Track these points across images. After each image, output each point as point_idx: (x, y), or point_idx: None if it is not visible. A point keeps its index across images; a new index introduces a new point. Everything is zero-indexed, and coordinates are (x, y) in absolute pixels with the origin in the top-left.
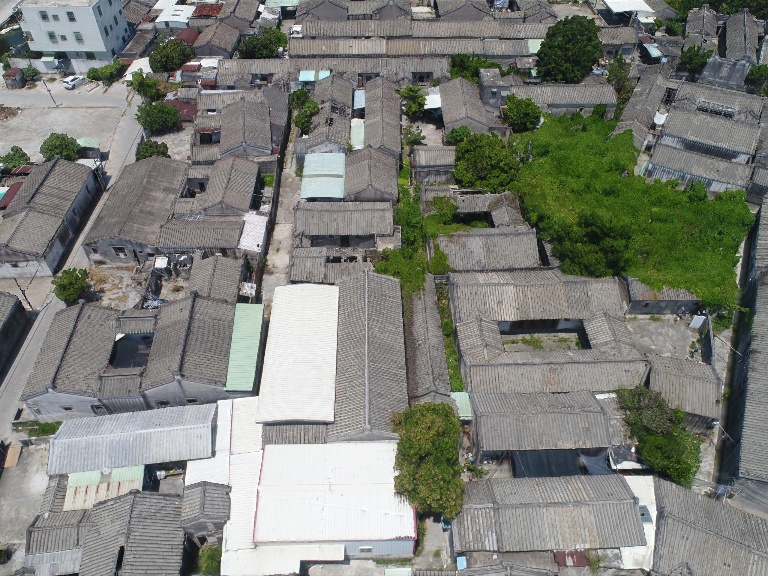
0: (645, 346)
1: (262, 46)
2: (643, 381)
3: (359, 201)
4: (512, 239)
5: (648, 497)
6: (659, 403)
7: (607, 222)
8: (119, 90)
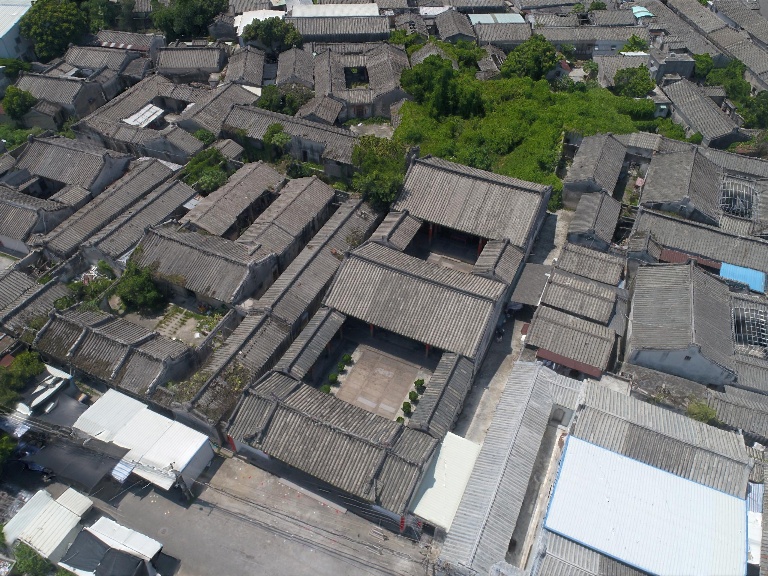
0: (367, 131)
1: None
2: None
3: None
4: None
5: None
6: (300, 96)
7: (429, 59)
8: None
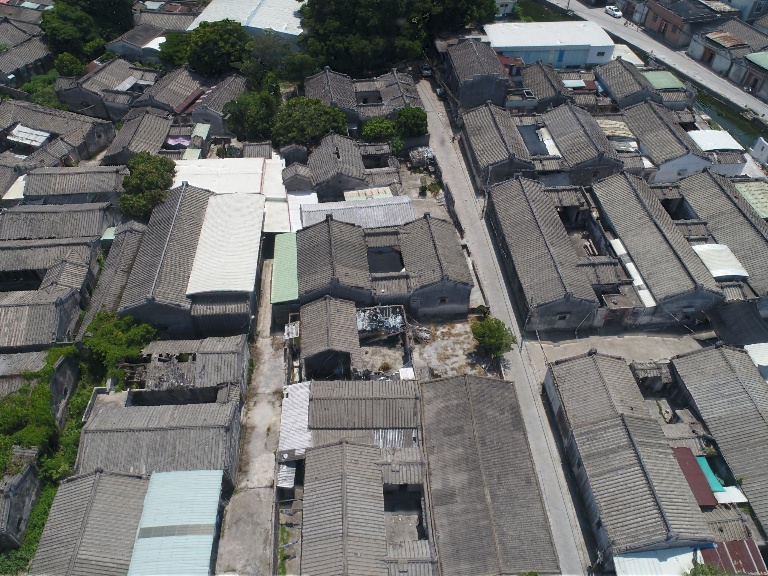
0: None
1: None
2: None
3: None
4: None
5: (17, 186)
6: None
7: None
8: None
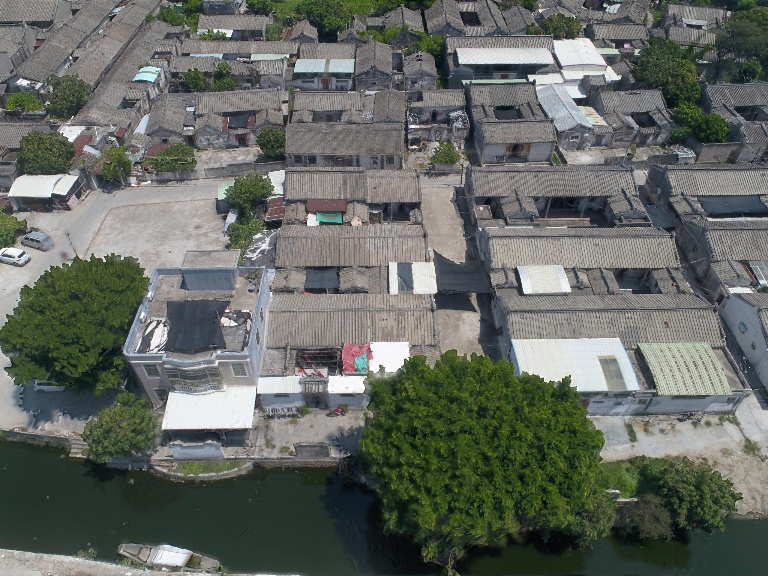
0: None
1: None
2: (495, 3)
3: (355, 57)
4: (406, 13)
5: None
6: None
7: None
8: (54, 221)
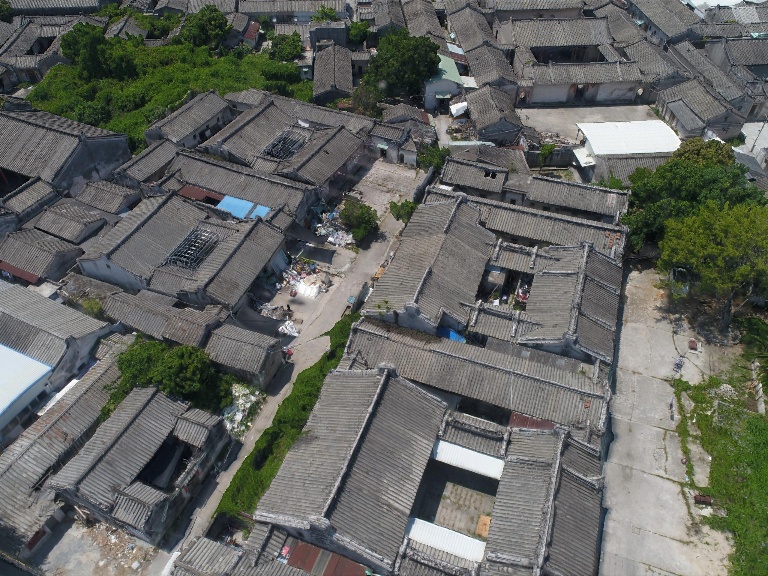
0: None
1: None
2: None
3: None
4: None
5: None
6: None
7: None
8: None
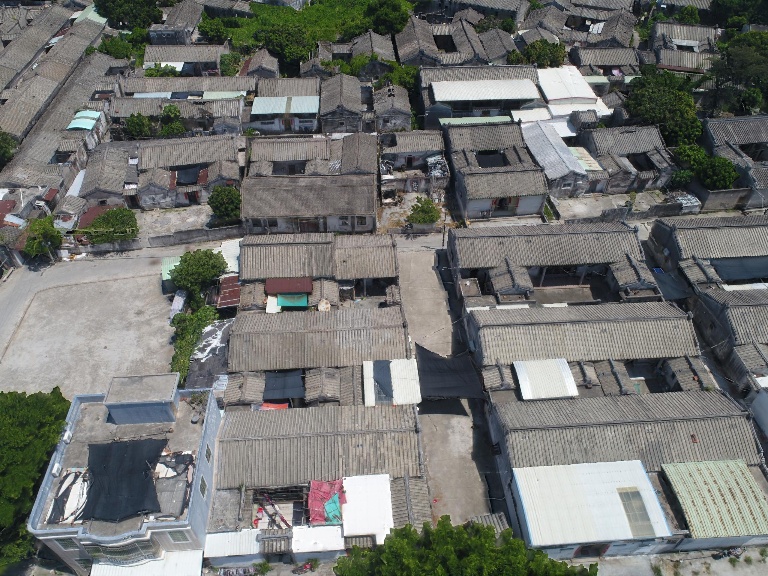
0: None
1: (2, 143)
2: None
3: (320, 93)
4: (374, 39)
5: None
6: None
7: None
8: None
